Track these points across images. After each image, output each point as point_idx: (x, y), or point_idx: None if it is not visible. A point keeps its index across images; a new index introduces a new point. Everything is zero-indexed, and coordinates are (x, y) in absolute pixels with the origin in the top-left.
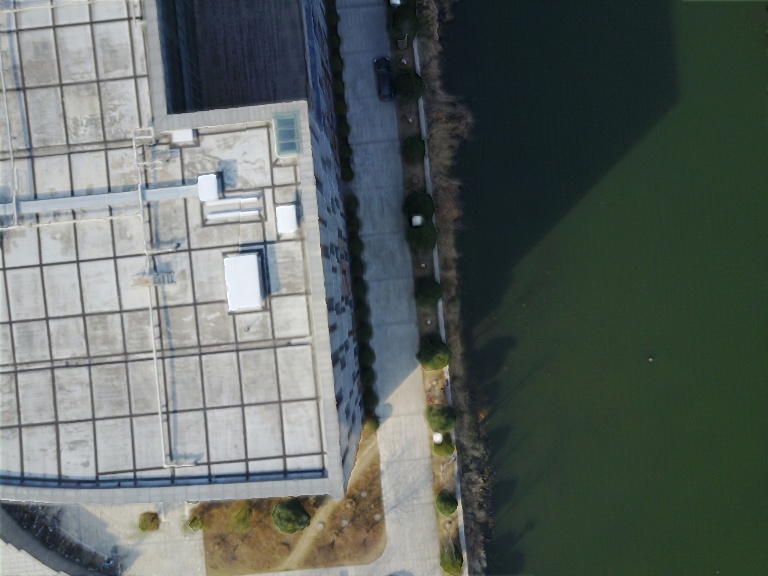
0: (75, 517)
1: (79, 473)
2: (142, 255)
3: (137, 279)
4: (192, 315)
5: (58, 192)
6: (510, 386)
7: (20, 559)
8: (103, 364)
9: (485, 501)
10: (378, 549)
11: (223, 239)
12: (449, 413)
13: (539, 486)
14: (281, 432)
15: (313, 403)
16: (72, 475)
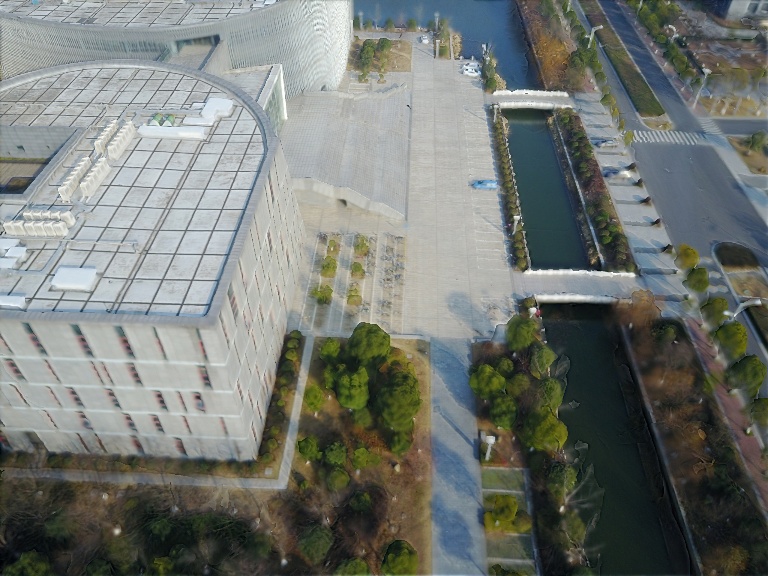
0: None
1: None
2: None
3: None
4: None
5: None
6: None
7: None
8: None
9: None
10: None
11: None
12: None
13: None
14: None
15: None
16: None
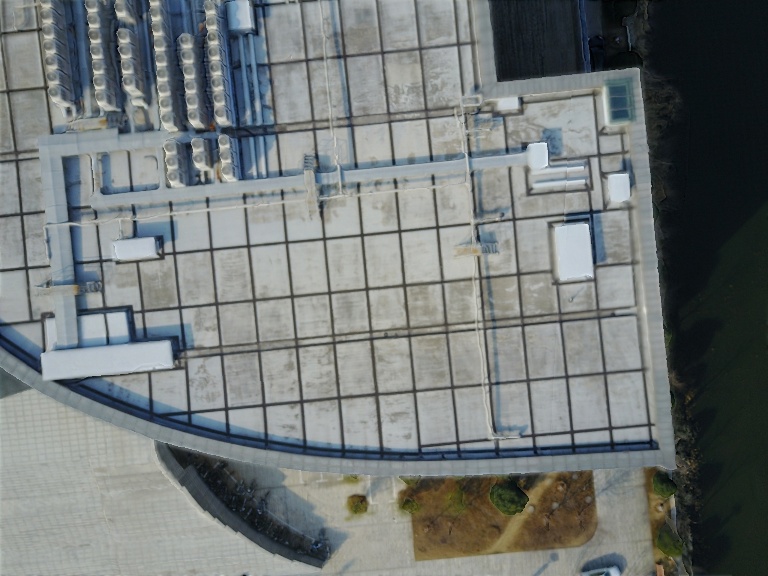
0: (282, 500)
1: (401, 445)
2: (465, 225)
3: (463, 249)
4: (515, 285)
5: (379, 161)
6: (717, 368)
7: (232, 542)
8: (423, 335)
9: (691, 484)
10: (589, 532)
11: (548, 208)
12: (671, 394)
13: (746, 468)
14: (606, 404)
15: (639, 374)
16: (394, 447)
